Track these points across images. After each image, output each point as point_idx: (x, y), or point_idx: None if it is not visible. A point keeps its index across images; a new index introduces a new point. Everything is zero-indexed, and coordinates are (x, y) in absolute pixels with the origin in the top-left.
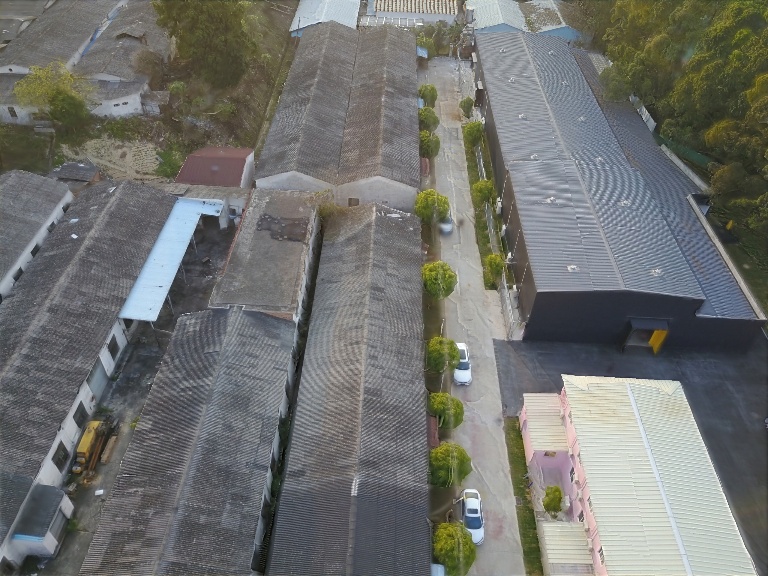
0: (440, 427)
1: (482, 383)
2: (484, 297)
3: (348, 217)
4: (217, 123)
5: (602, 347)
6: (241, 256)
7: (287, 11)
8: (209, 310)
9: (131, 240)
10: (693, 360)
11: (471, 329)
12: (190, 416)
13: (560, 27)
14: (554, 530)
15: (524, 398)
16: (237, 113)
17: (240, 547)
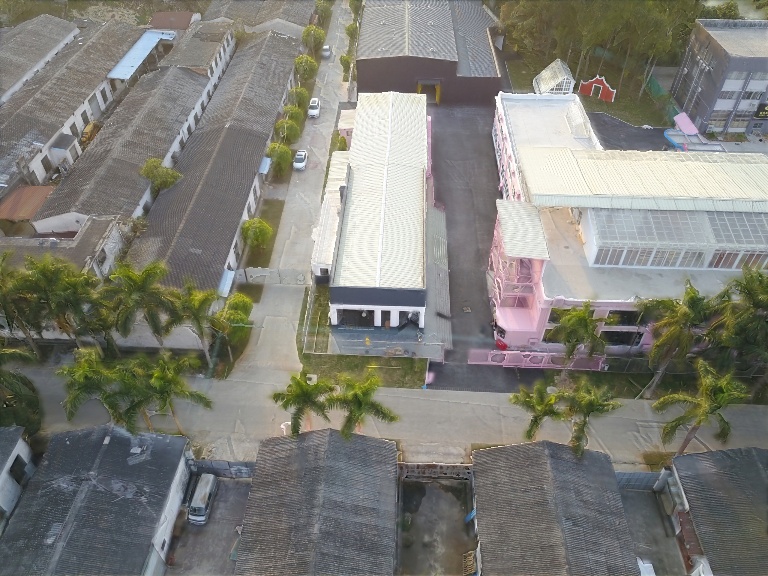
0: None
1: (326, 118)
2: (340, 85)
3: (254, 38)
4: (177, 1)
5: None
6: (180, 48)
7: None
8: (159, 70)
9: (115, 46)
10: (461, 108)
11: (327, 98)
12: (143, 102)
13: None
14: (338, 153)
15: (341, 112)
16: None
17: (164, 143)
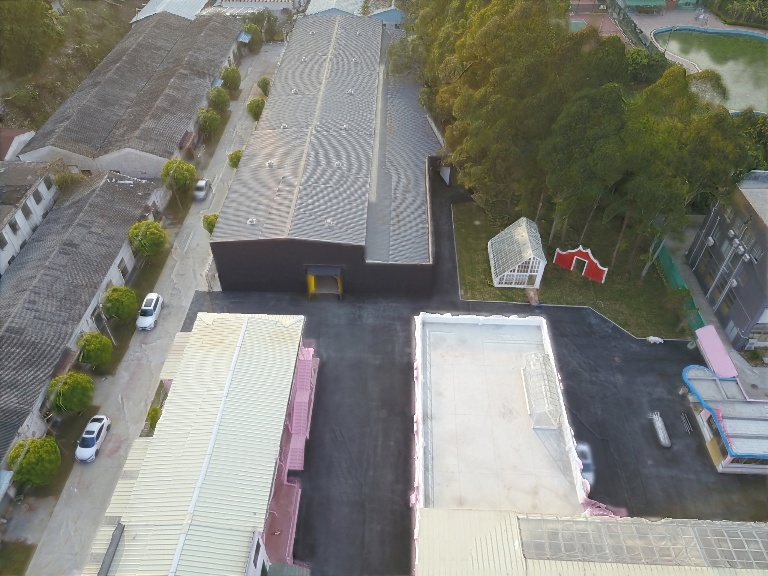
0: (84, 362)
1: (165, 328)
2: (206, 255)
3: (82, 185)
4: (12, 107)
5: (294, 295)
6: None
7: (141, 5)
8: None
9: None
10: (375, 305)
11: (179, 283)
12: None
13: (388, 10)
14: (141, 444)
15: (175, 336)
16: (38, 98)
17: None
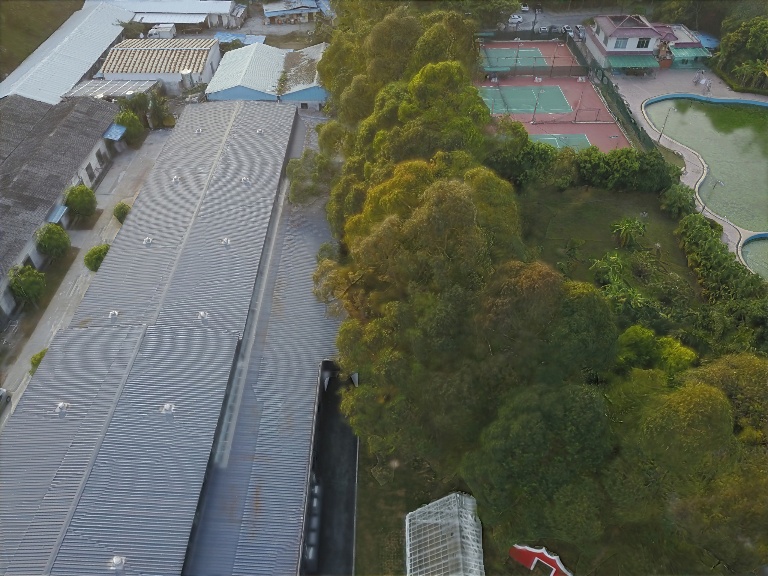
0: None
1: None
2: None
3: None
4: None
5: None
6: None
7: (4, 76)
8: None
9: None
10: None
11: None
12: None
13: (309, 87)
14: None
15: None
16: None
17: None
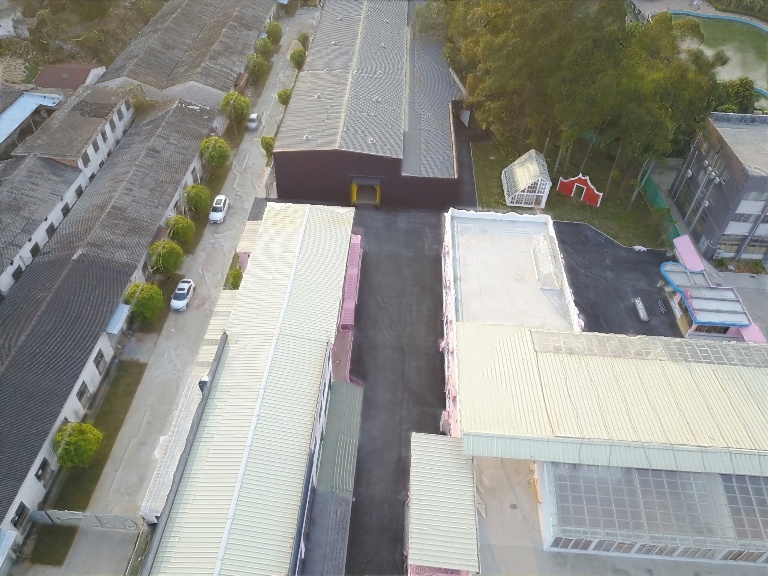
0: (173, 238)
1: (232, 223)
2: (262, 172)
3: (156, 108)
4: (82, 47)
5: (339, 204)
6: (51, 125)
7: None
8: (14, 158)
9: None
10: (408, 213)
11: (241, 191)
12: None
13: None
14: (227, 294)
15: (246, 223)
16: (104, 41)
17: None
